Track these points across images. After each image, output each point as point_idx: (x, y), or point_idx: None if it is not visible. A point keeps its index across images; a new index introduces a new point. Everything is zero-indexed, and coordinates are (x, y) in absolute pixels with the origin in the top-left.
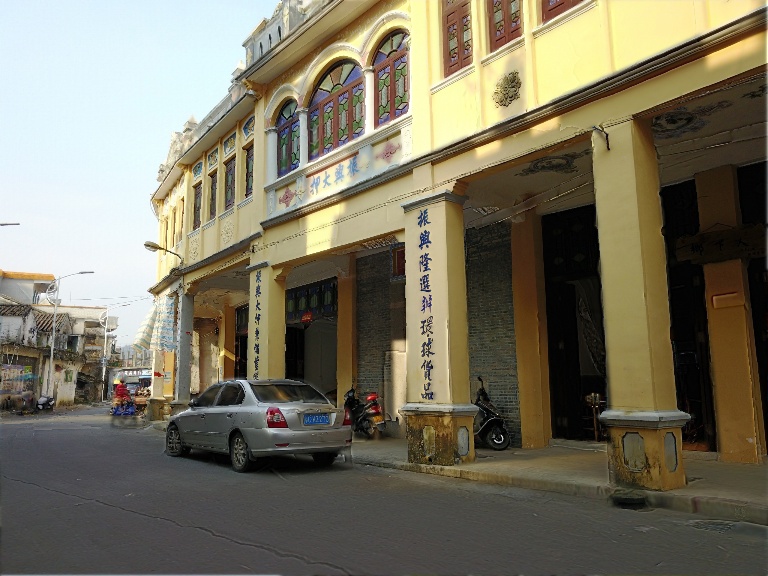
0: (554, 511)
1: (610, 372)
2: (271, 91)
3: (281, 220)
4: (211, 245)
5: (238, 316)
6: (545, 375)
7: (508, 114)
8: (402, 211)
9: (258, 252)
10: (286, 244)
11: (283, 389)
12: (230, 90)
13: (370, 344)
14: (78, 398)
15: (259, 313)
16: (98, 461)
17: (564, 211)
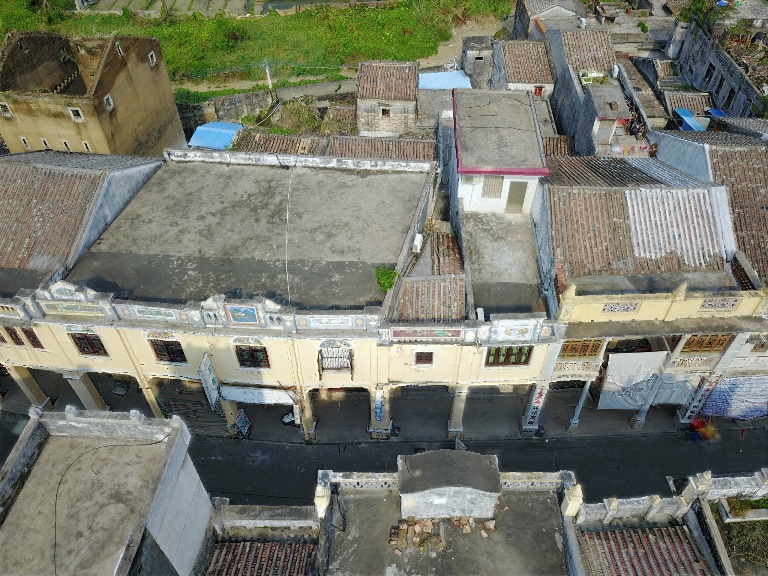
0: None
1: (30, 399)
2: None
3: None
4: None
5: None
6: None
7: None
8: None
9: None
10: None
11: None
12: None
13: None
14: None
15: None
16: None
17: None
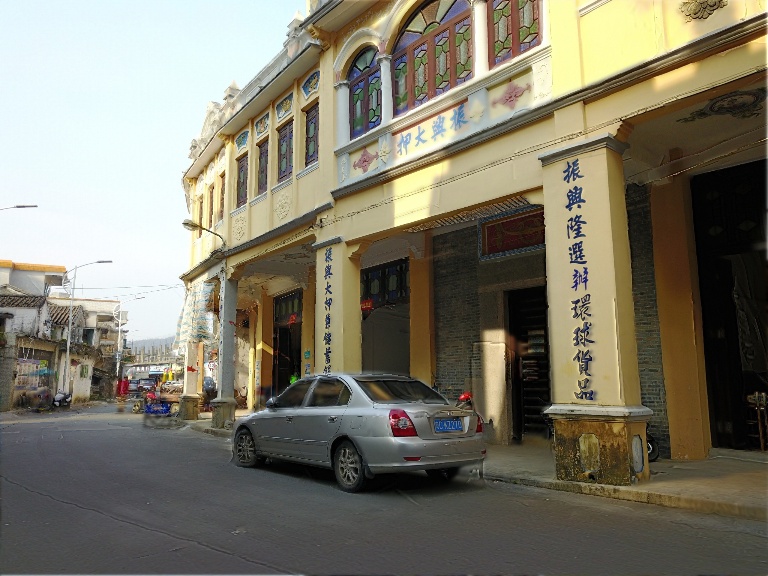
0: None
1: None
2: (341, 39)
3: (359, 187)
4: (261, 223)
5: (276, 306)
6: (701, 370)
7: (708, 28)
8: (537, 165)
9: (327, 226)
10: (366, 215)
11: (393, 386)
12: (286, 44)
13: (452, 334)
14: (93, 394)
15: (330, 297)
16: (157, 474)
17: (729, 168)
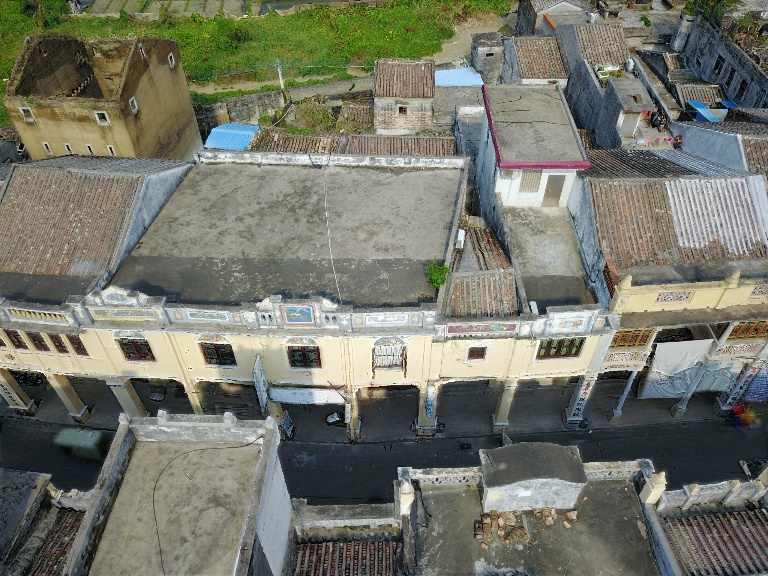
0: (66, 440)
1: None
2: None
3: None
4: None
5: None
6: None
7: None
8: None
9: None
10: None
11: None
12: None
13: None
14: None
15: None
16: None
17: None
